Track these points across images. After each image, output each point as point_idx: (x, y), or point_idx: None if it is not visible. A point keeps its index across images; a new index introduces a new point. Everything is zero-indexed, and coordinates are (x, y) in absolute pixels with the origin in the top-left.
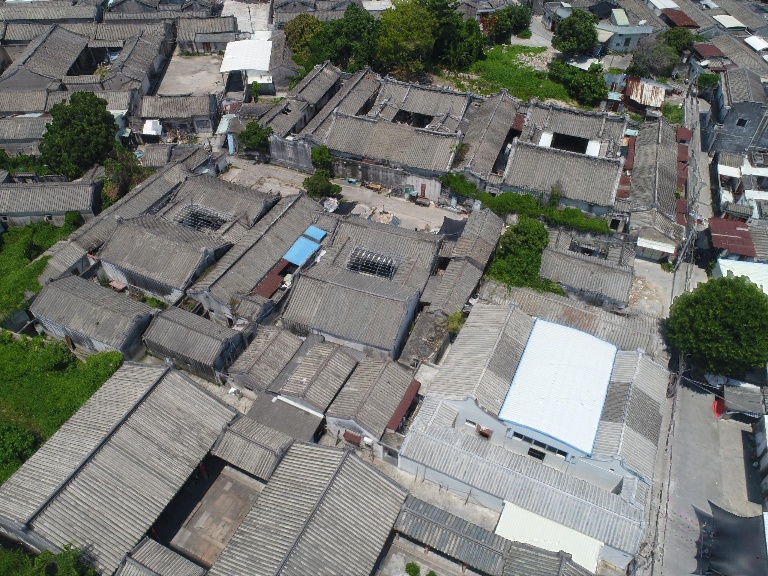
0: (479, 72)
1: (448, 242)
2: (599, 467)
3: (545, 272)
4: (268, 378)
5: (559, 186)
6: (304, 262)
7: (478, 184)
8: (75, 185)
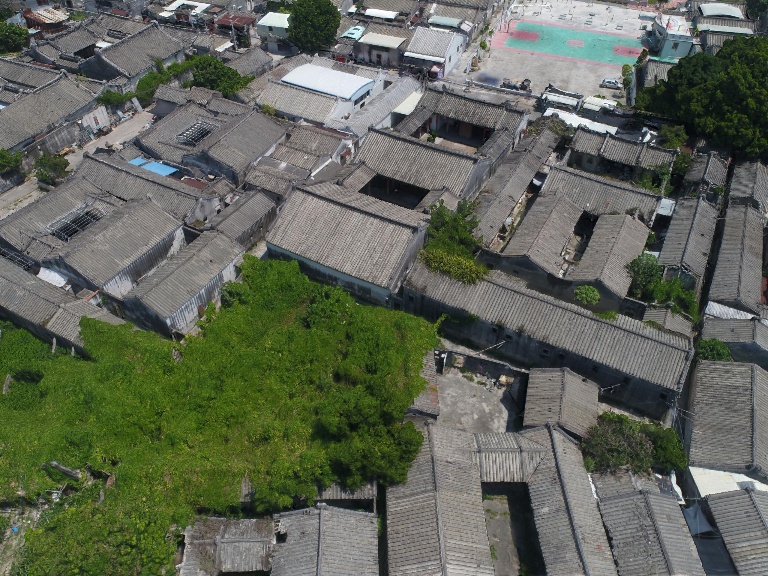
0: None
1: None
2: None
3: None
4: (296, 177)
5: (153, 57)
6: (177, 164)
7: None
8: None
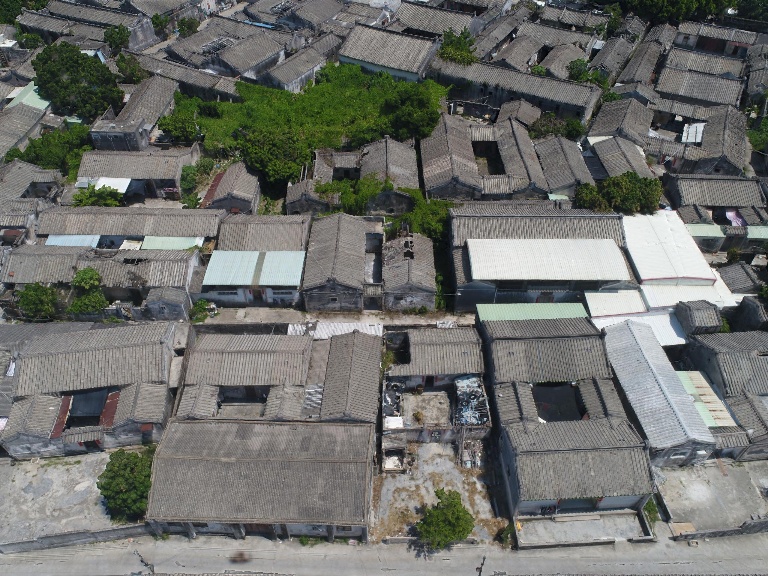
0: None
1: None
2: None
3: None
4: None
5: None
6: (273, 23)
7: None
8: (152, 81)
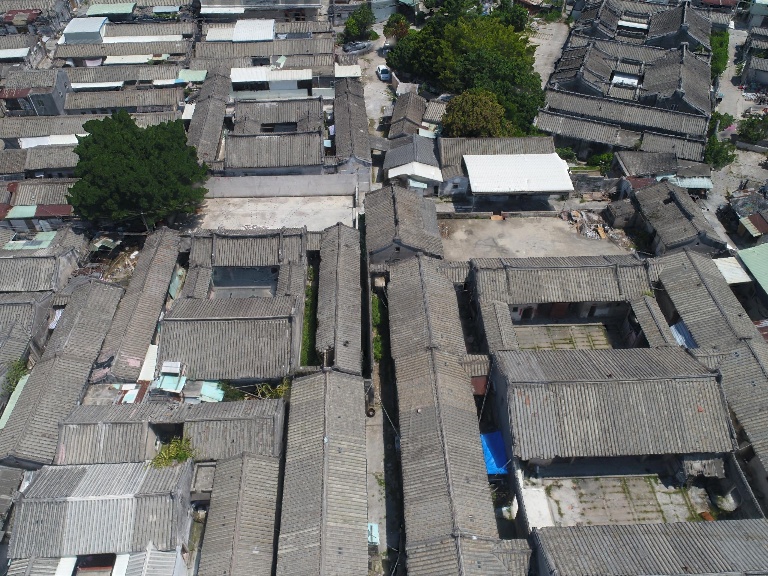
0: None
1: None
2: None
3: None
4: None
5: None
6: None
7: None
8: None
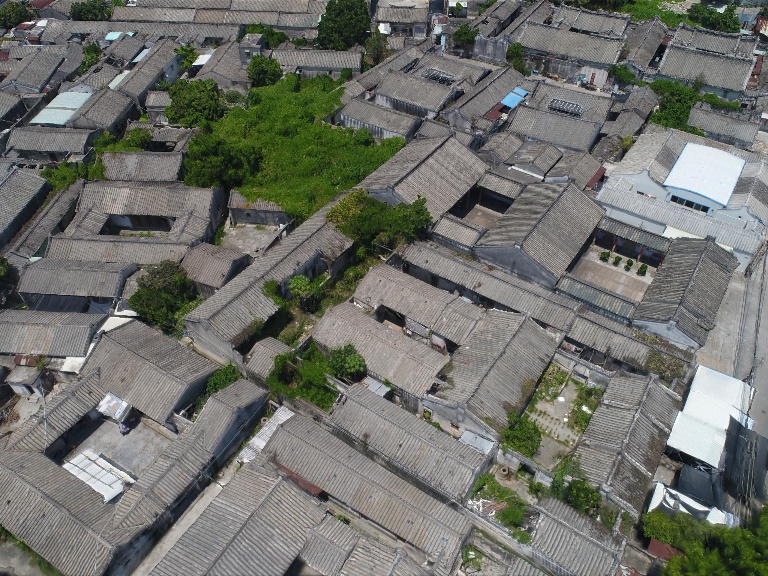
0: (629, 12)
1: (618, 103)
2: (731, 216)
3: (692, 122)
4: (505, 157)
5: (702, 77)
6: (516, 105)
7: (637, 75)
8: (349, 52)
